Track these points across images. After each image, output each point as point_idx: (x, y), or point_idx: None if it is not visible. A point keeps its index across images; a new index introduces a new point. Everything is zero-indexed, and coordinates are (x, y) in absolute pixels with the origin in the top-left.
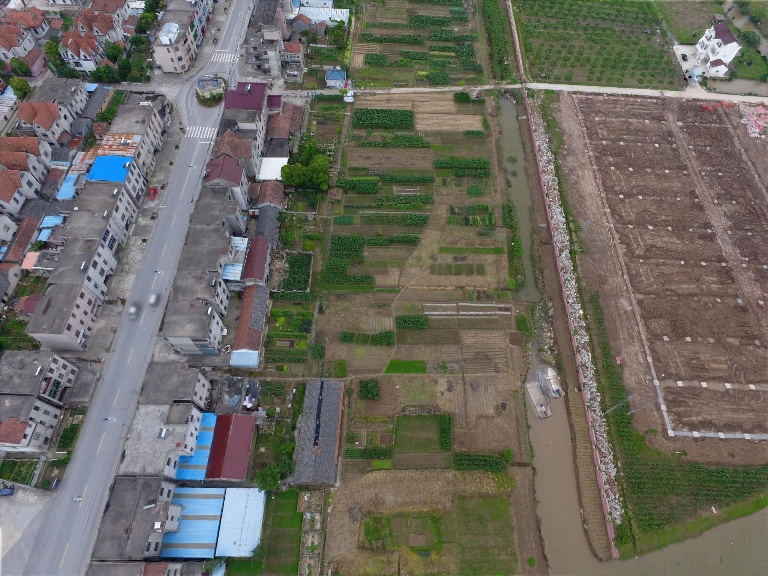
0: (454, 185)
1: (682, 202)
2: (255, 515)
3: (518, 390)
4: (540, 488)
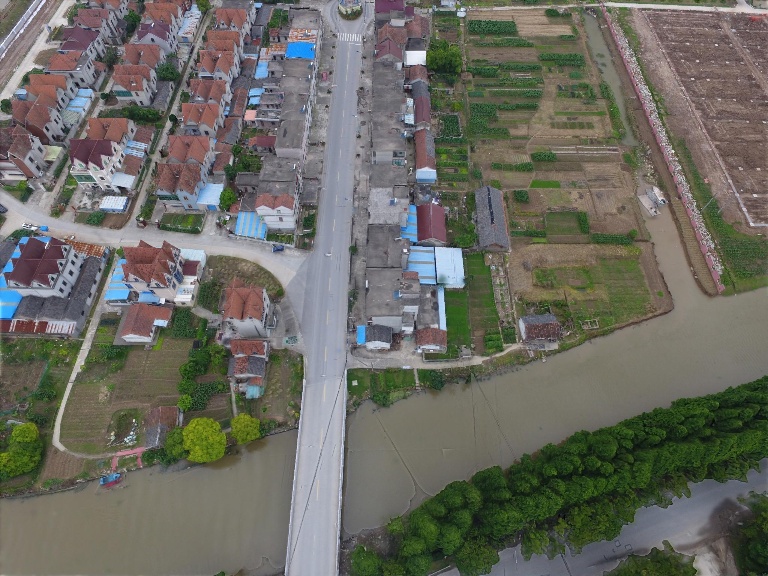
0: (558, 72)
1: (742, 83)
2: (459, 263)
3: (633, 198)
4: (658, 256)
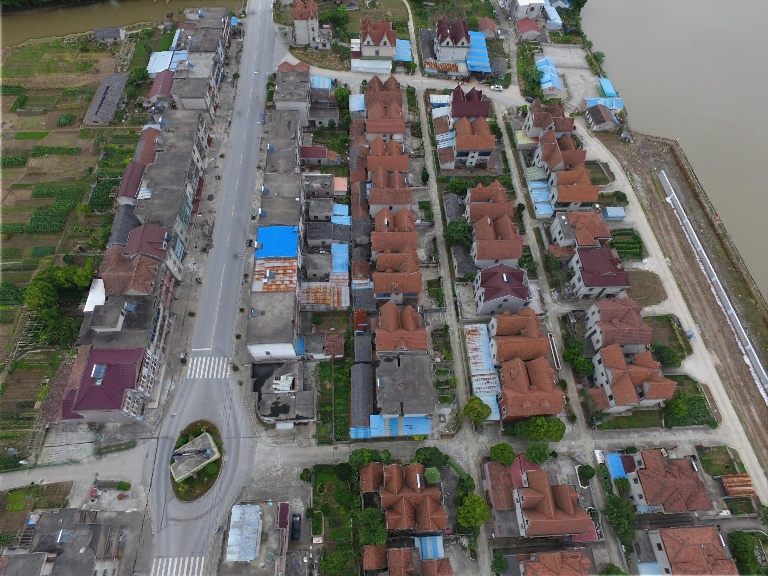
0: None
1: None
2: None
3: None
4: None
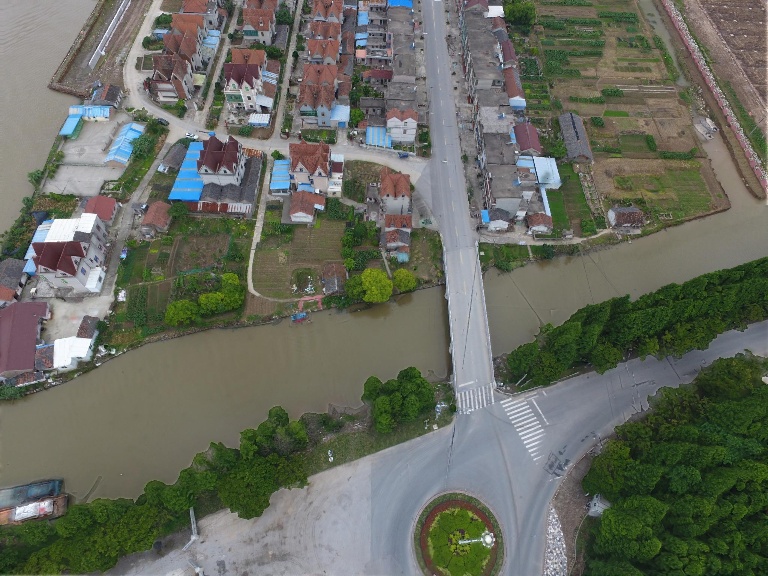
0: (616, 26)
1: None
2: (554, 168)
3: (690, 125)
4: (715, 169)
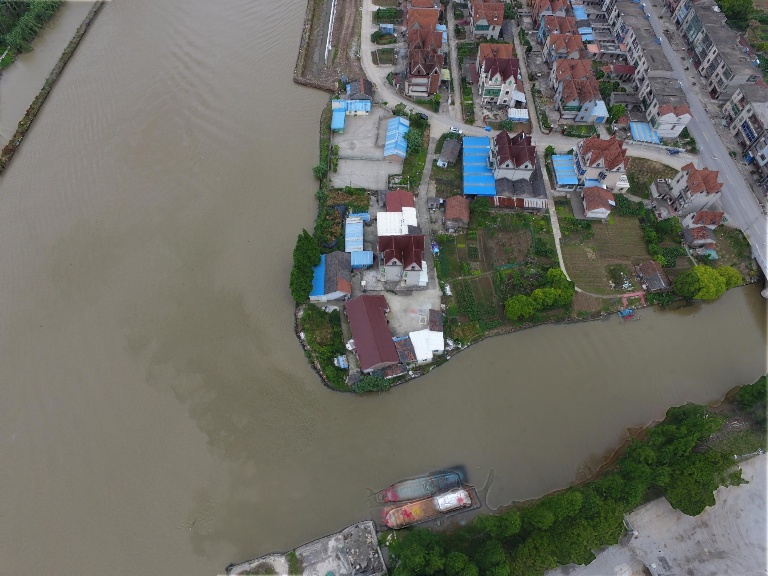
0: None
1: None
2: None
3: None
4: None
